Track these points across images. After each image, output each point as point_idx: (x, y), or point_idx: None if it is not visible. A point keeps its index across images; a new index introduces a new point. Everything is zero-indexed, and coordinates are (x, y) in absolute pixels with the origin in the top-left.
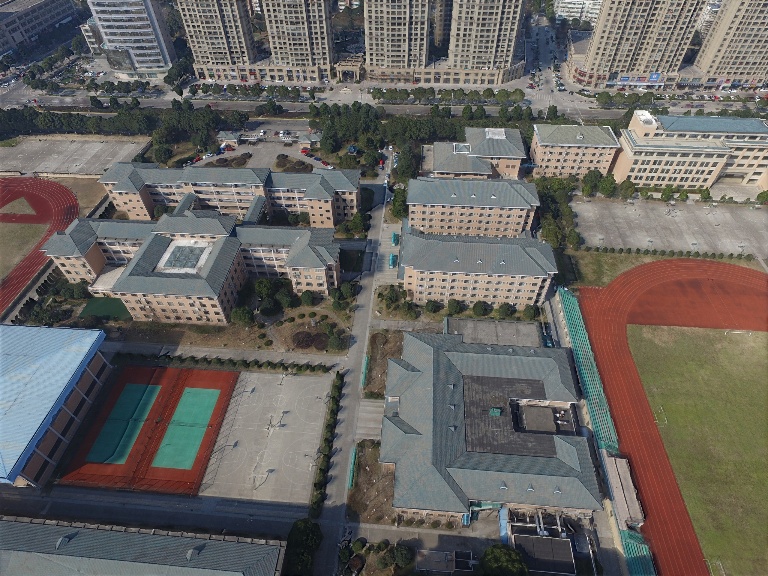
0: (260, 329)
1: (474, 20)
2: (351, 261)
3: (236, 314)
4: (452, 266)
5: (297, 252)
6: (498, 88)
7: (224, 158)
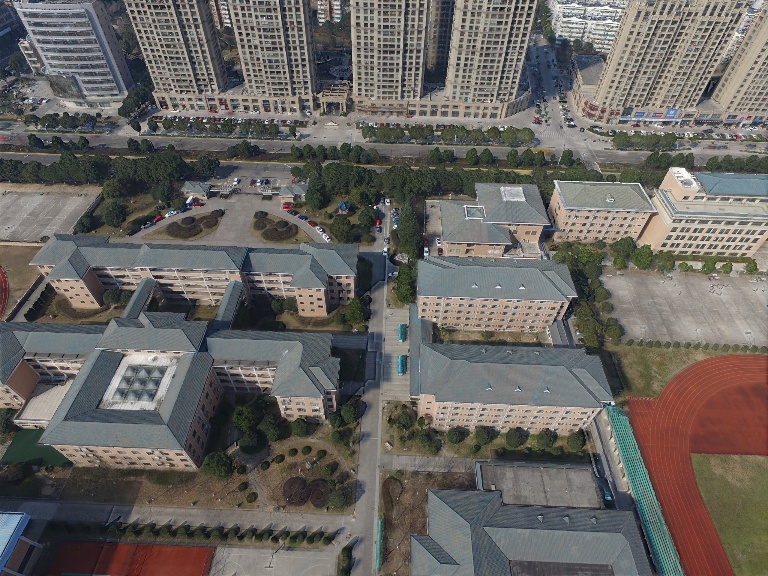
0: (240, 475)
1: (477, 49)
2: (351, 368)
3: (209, 468)
4: (484, 396)
5: (286, 375)
6: (502, 123)
7: (191, 216)
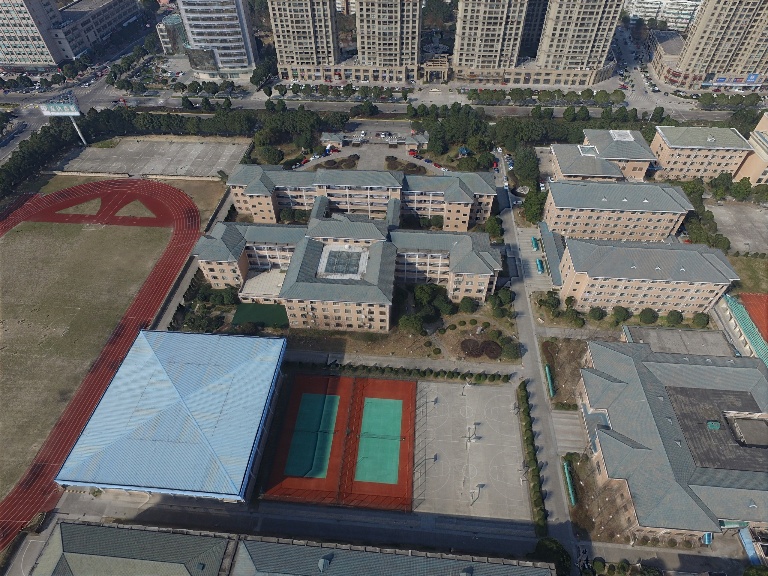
0: (424, 337)
1: (572, 20)
2: None
3: (409, 322)
4: (629, 273)
5: (461, 258)
6: None
7: (332, 160)
